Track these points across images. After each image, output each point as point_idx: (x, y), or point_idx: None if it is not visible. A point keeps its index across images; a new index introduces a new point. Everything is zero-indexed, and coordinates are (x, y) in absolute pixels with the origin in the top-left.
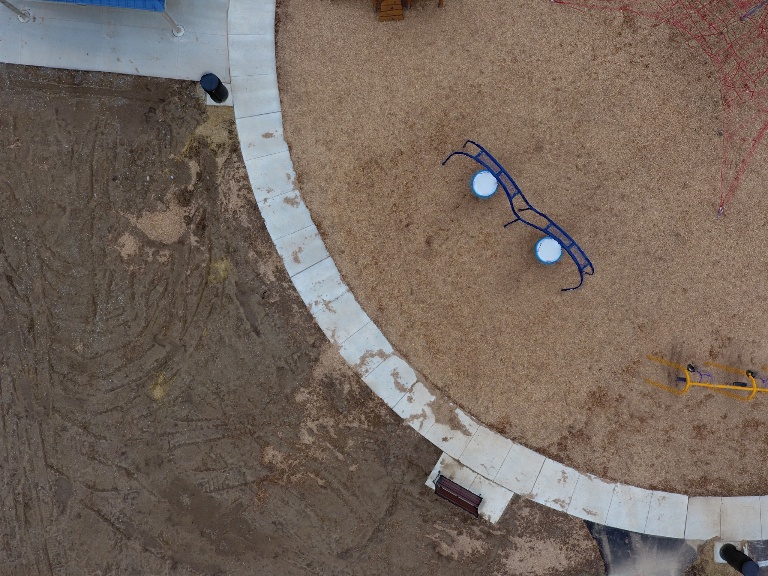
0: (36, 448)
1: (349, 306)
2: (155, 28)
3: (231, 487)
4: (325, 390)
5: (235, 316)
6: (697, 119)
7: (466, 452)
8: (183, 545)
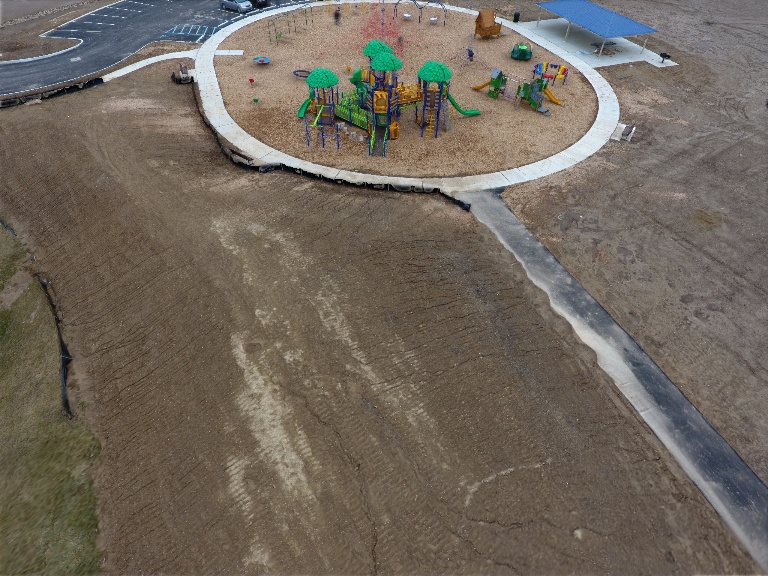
0: None
1: None
2: None
3: None
4: (443, 1)
5: None
6: None
7: None
8: None
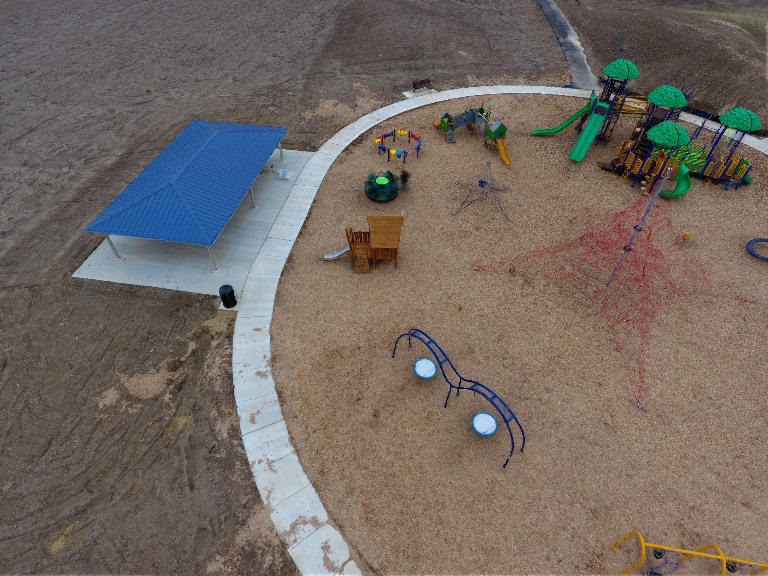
0: None
1: (291, 467)
2: (201, 268)
3: None
4: (243, 561)
5: (176, 468)
6: (595, 340)
7: None
8: None
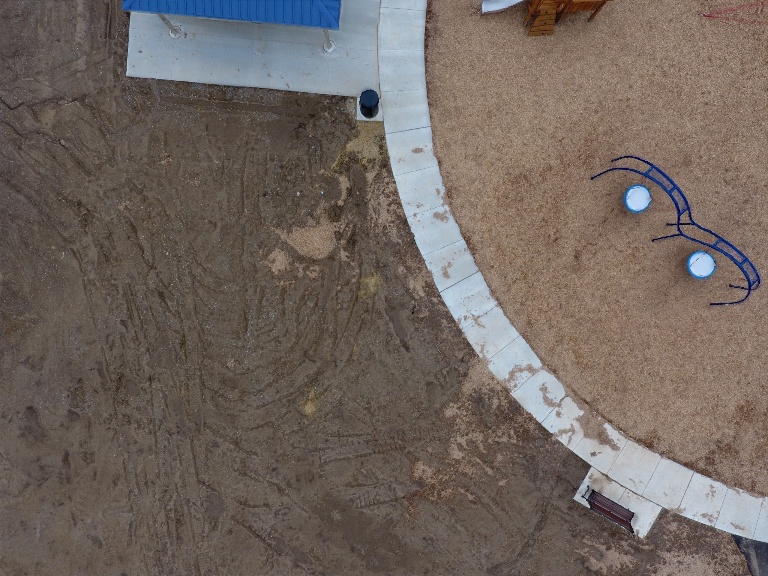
0: (188, 464)
1: (498, 321)
2: (306, 44)
3: (382, 502)
4: (474, 405)
5: (385, 331)
6: None
7: (614, 467)
8: (334, 561)
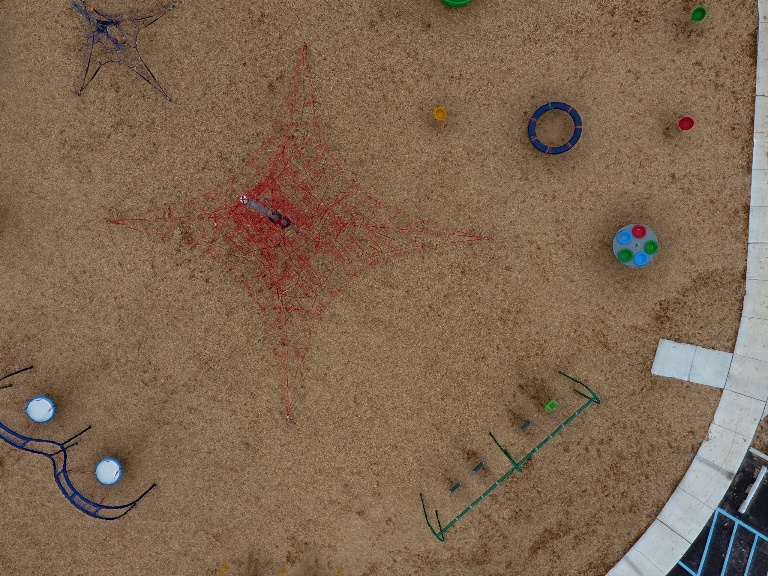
0: None
1: None
2: None
3: None
4: None
5: None
6: (262, 329)
7: None
8: None
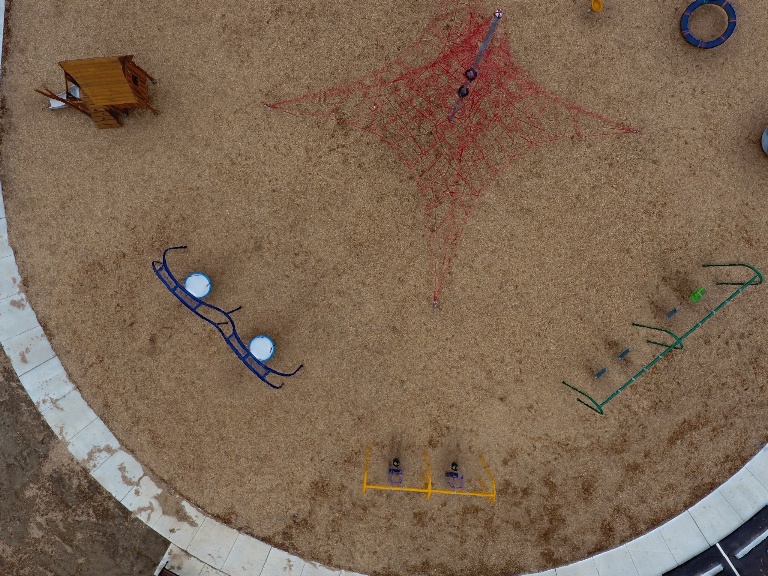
0: None
1: (76, 403)
2: None
3: None
4: (55, 485)
5: None
6: (411, 216)
7: (193, 543)
8: None
